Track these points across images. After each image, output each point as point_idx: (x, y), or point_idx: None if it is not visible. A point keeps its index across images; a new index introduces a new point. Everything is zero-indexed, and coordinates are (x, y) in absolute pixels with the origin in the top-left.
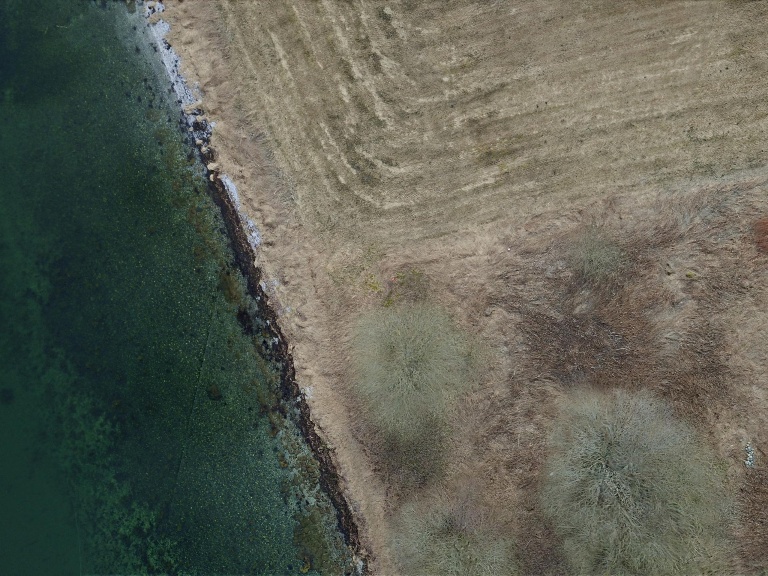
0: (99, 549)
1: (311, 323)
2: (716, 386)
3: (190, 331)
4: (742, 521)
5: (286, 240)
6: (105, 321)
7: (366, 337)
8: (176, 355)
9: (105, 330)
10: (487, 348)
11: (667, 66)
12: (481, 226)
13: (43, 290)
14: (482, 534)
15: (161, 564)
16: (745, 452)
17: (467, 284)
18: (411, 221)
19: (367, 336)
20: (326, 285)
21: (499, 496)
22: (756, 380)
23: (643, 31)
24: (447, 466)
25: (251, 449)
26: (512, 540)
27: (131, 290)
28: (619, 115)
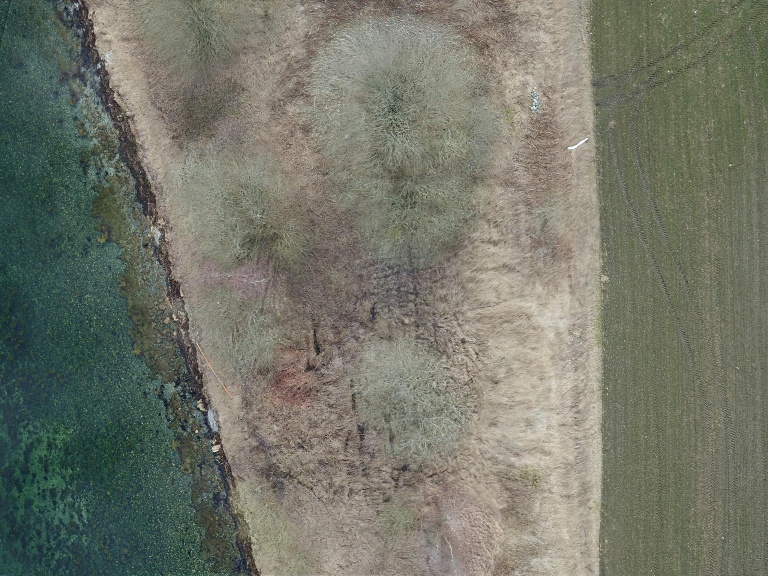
0: None
1: None
2: (505, 35)
3: None
4: (527, 168)
5: None
6: None
7: None
8: None
9: None
10: (283, 8)
11: None
12: None
13: None
14: (279, 202)
15: None
16: (531, 97)
17: None
18: None
19: None
20: None
21: (295, 161)
22: (543, 25)
23: None
24: (245, 133)
25: (51, 118)
26: (307, 206)
27: None
28: None
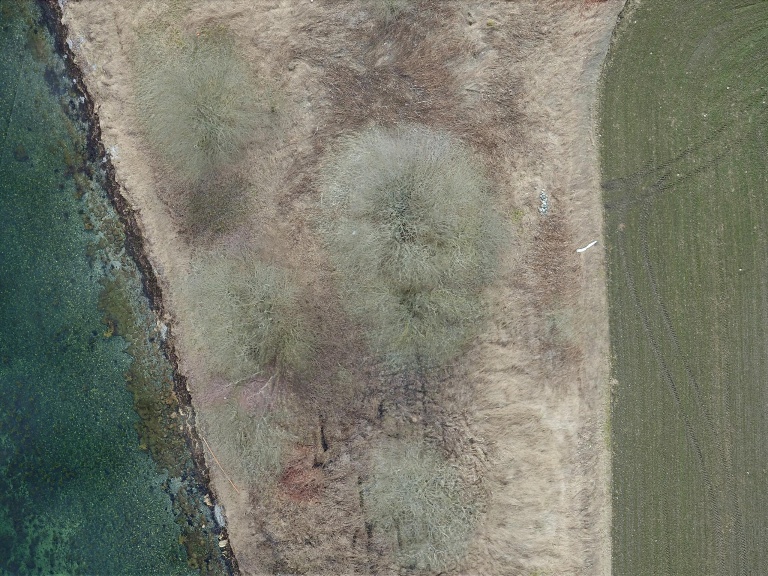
0: None
1: (116, 80)
2: (514, 135)
3: None
4: (536, 270)
5: None
6: None
7: (171, 95)
8: None
9: None
10: (290, 104)
11: None
12: None
13: None
14: (286, 297)
15: None
16: (539, 199)
17: (270, 37)
18: None
19: (172, 94)
20: (131, 41)
21: (302, 257)
22: (552, 126)
23: None
24: (251, 228)
25: (57, 212)
26: (314, 302)
27: None
28: None
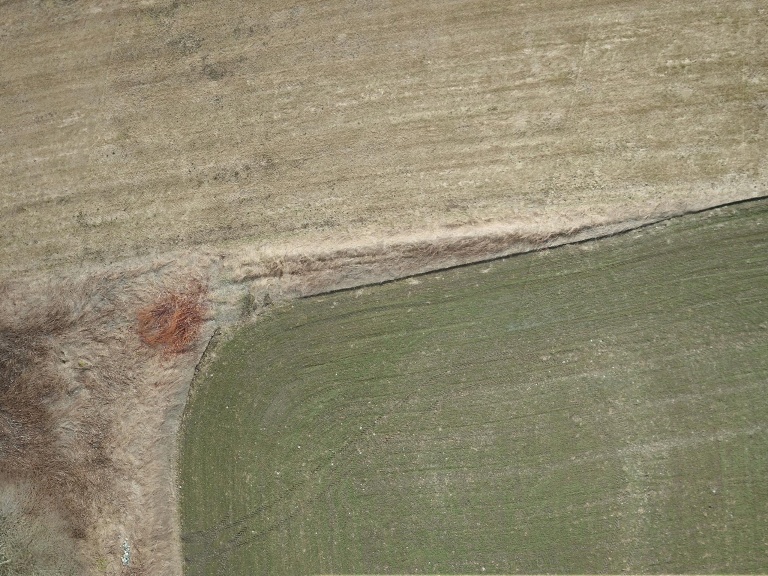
0: None
1: None
2: (102, 479)
3: None
4: None
5: None
6: None
7: None
8: None
9: None
10: None
11: (55, 150)
12: None
13: None
14: None
15: None
16: (122, 549)
17: None
18: None
19: None
20: None
21: None
22: (135, 475)
23: (32, 113)
24: None
25: None
26: None
27: None
28: (10, 199)
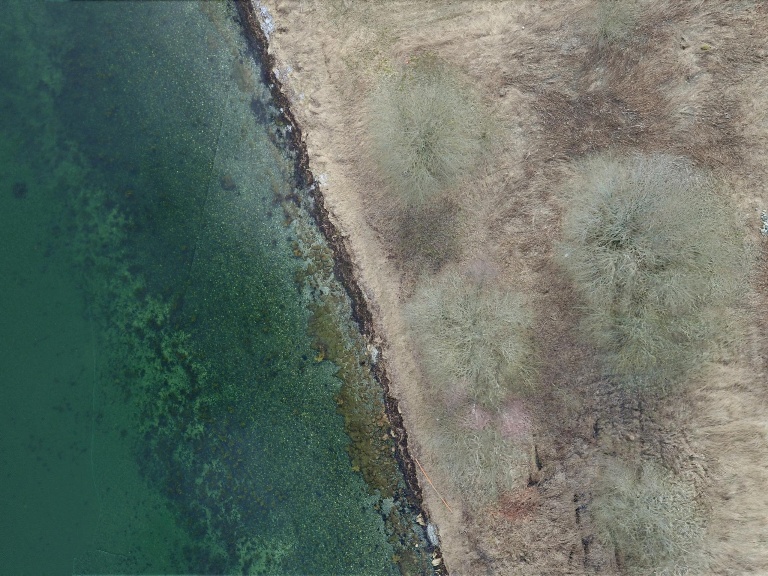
0: (113, 342)
1: (325, 109)
2: (731, 157)
3: (203, 121)
4: (758, 289)
5: (299, 25)
6: (118, 112)
7: (380, 122)
8: (189, 145)
9: (118, 121)
10: (501, 129)
11: None
12: (495, 5)
13: (55, 82)
14: (497, 319)
15: (175, 356)
16: (761, 220)
17: (481, 64)
18: (425, 3)
19: (381, 121)
20: (340, 70)
21: (514, 279)
22: None
23: None
24: (461, 252)
25: (265, 239)
26: (527, 323)
27: (144, 80)
28: None
